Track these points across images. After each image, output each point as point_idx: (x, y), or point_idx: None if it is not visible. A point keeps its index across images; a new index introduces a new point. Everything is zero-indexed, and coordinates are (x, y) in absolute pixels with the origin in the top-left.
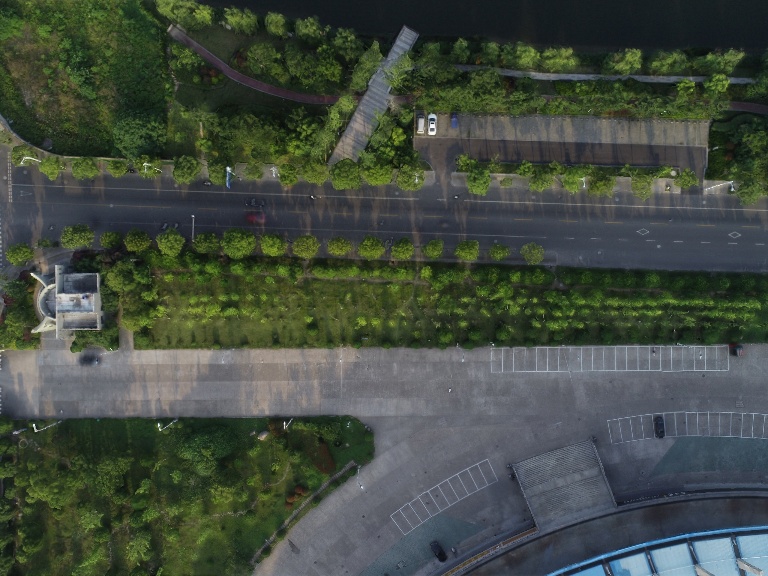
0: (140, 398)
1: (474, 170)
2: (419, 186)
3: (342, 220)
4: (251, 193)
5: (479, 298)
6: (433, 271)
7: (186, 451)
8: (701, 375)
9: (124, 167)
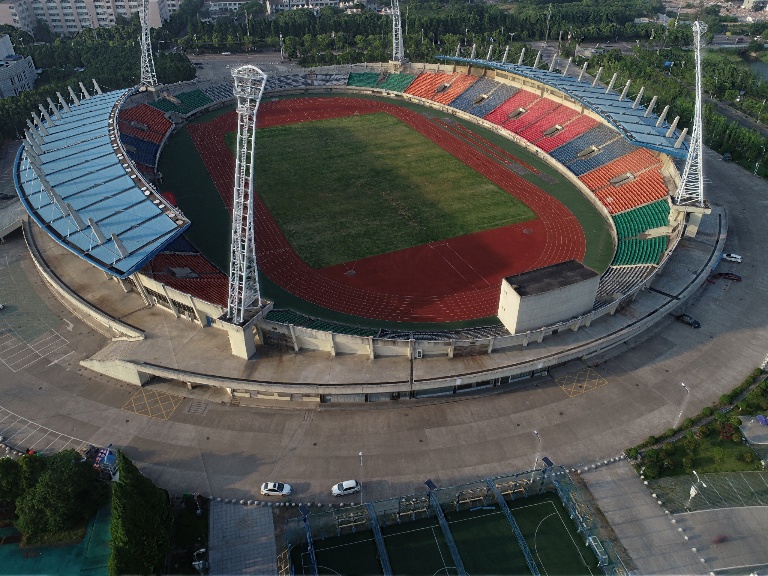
0: None
1: None
2: (711, 87)
3: None
4: None
5: None
6: None
7: None
8: None
9: None
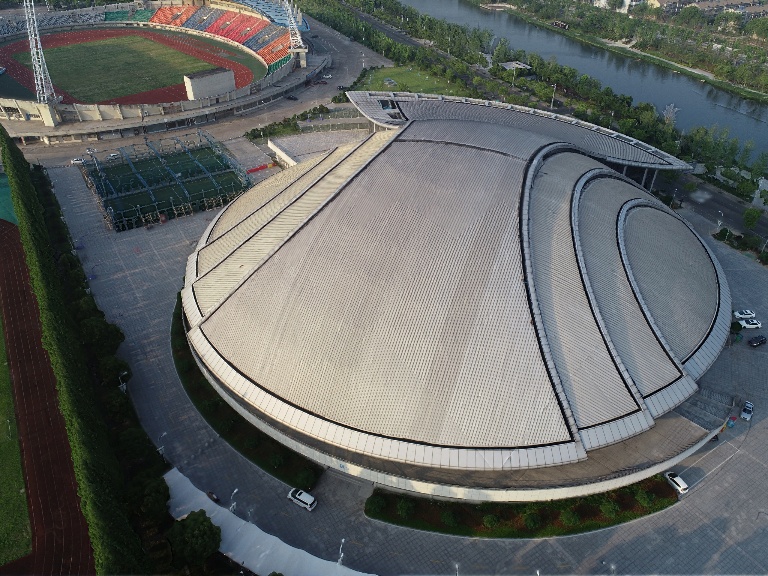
0: None
1: None
2: (360, 5)
3: None
4: None
5: None
6: None
7: None
8: None
9: None
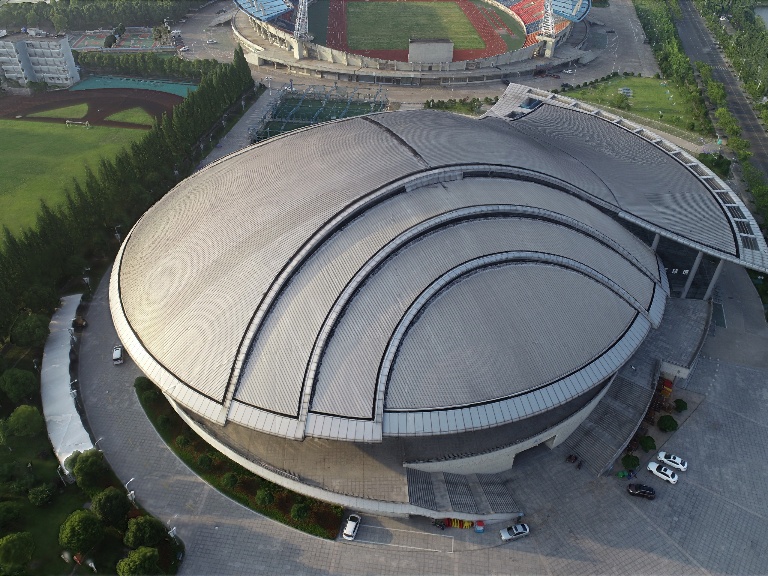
0: None
1: None
2: None
3: None
4: (688, 4)
5: None
6: None
7: None
8: None
9: None
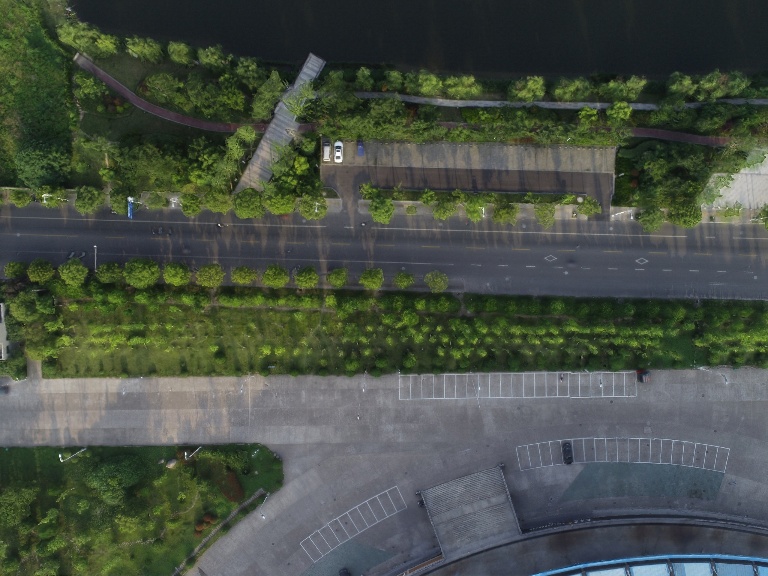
0: (49, 427)
1: (375, 199)
2: (322, 215)
3: (249, 248)
4: (158, 221)
5: (386, 325)
6: (338, 299)
7: (93, 480)
8: (609, 401)
9: (27, 197)
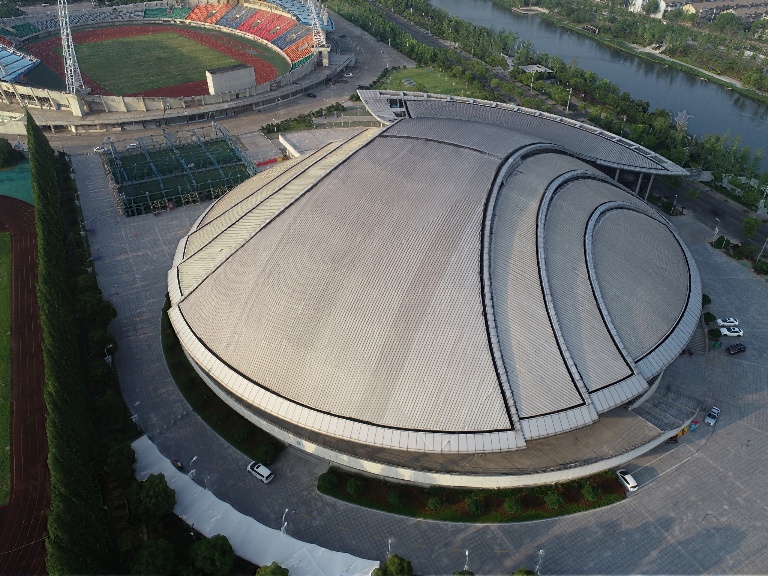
0: None
1: None
2: (392, 6)
3: None
4: None
5: None
6: None
7: None
8: None
9: None
